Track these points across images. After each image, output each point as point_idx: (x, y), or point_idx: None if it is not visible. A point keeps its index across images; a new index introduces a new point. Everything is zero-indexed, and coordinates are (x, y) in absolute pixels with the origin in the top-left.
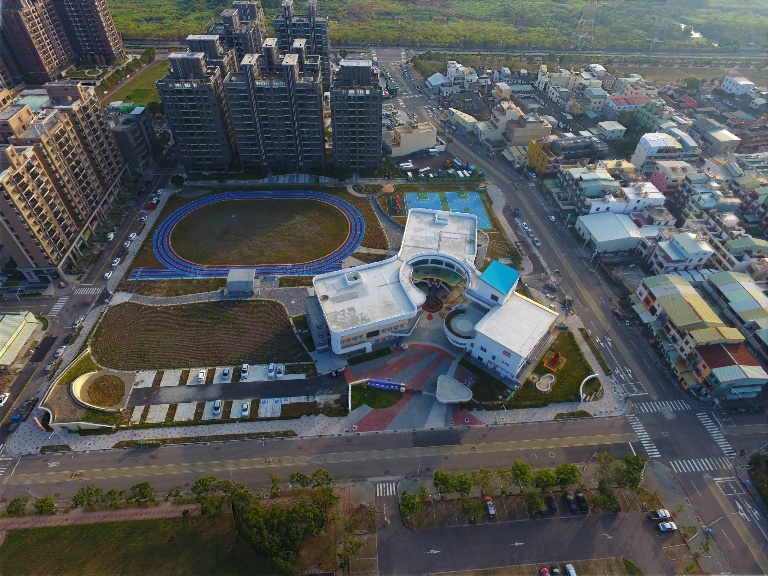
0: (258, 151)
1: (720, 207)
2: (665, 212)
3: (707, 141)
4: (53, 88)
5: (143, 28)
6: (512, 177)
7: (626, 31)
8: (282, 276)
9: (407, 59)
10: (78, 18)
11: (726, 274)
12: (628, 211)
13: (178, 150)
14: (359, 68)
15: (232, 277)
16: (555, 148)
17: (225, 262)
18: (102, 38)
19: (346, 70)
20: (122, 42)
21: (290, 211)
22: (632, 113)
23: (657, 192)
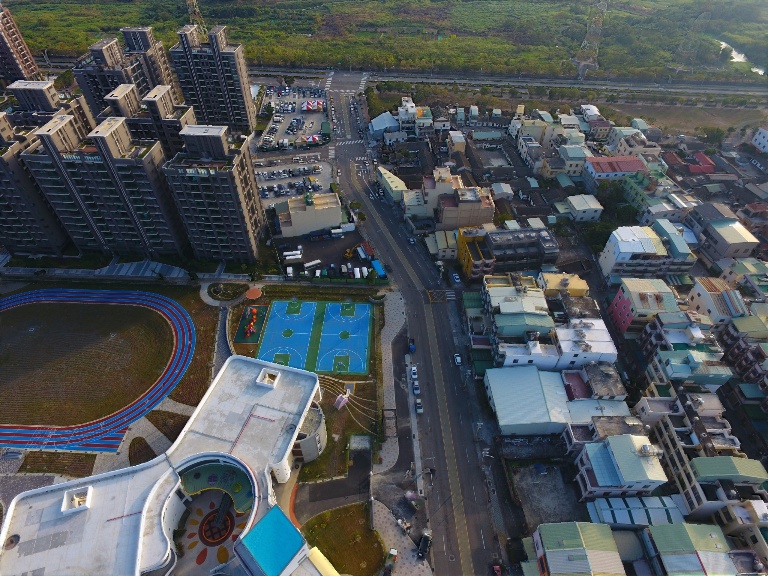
0: (93, 234)
1: (698, 379)
2: (613, 377)
3: (711, 237)
4: None
5: (91, 41)
6: (428, 279)
7: (648, 53)
8: (33, 450)
9: (365, 88)
10: None
11: (680, 531)
12: (562, 365)
13: None
14: (206, 138)
15: None
16: (487, 244)
17: None
18: (9, 60)
19: (189, 139)
20: (48, 61)
21: (108, 325)
22: (615, 185)
23: (607, 340)
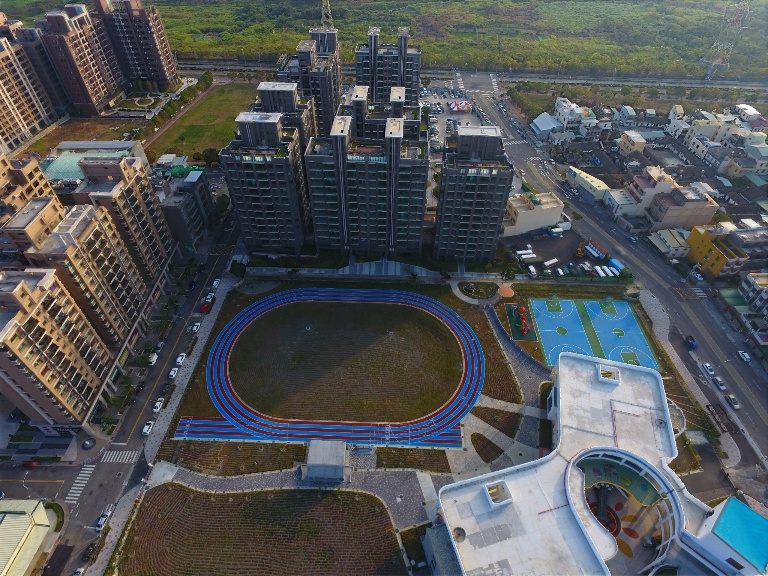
0: (339, 234)
1: None
2: None
3: None
4: (89, 166)
5: (199, 42)
6: (669, 277)
7: (759, 53)
8: (379, 446)
9: (500, 89)
10: (130, 40)
11: None
12: None
13: (240, 230)
14: (483, 138)
15: (314, 456)
16: (733, 243)
17: (301, 413)
18: (155, 62)
19: (465, 140)
20: (177, 63)
21: (381, 324)
22: None
23: None
